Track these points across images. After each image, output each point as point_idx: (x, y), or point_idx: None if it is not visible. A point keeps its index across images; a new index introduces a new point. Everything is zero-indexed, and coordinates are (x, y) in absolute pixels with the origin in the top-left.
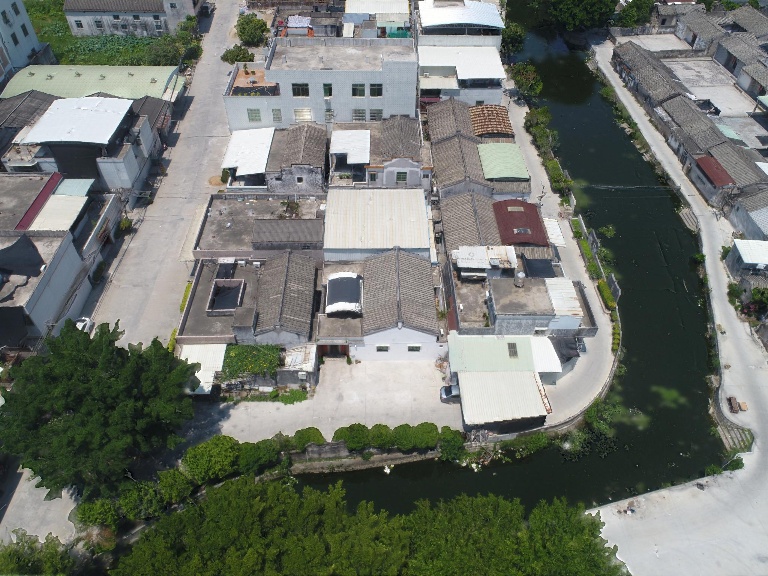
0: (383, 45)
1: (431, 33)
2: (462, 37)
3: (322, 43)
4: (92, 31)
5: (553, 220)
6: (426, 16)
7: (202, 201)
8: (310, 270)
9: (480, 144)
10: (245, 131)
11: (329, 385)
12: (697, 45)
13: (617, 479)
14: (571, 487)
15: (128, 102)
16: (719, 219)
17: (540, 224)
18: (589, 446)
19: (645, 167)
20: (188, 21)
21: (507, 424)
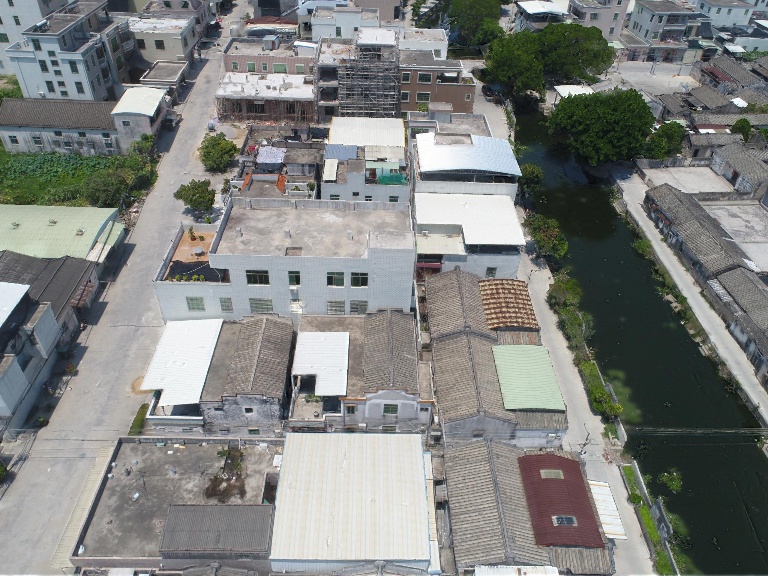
0: (371, 209)
1: (431, 176)
2: (469, 184)
3: (292, 206)
4: (29, 147)
5: (603, 484)
6: (425, 156)
7: (116, 422)
8: None
9: (496, 345)
10: (183, 323)
11: None
12: (740, 185)
13: None
14: None
15: (21, 289)
16: None
17: (588, 501)
18: None
19: (703, 362)
20: (143, 141)
21: None
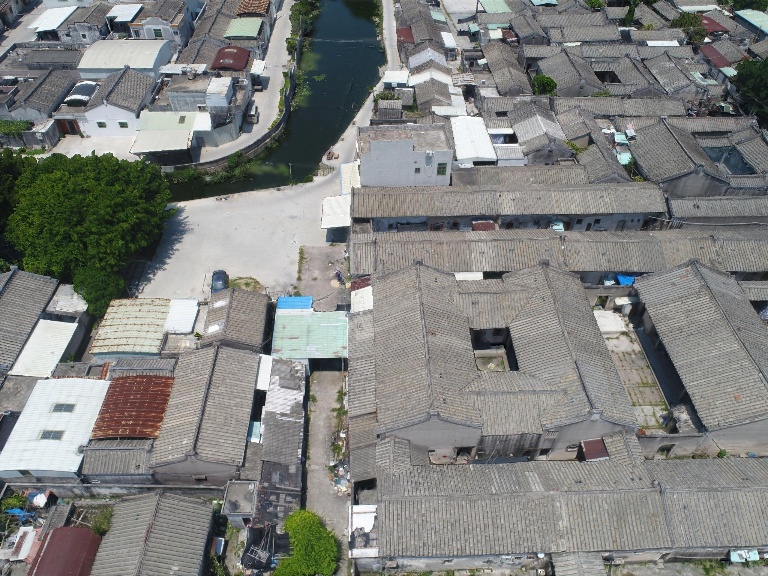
0: None
1: None
2: None
3: None
4: None
5: (262, 61)
6: None
7: None
8: (65, 82)
9: (234, 19)
10: (56, 9)
11: (63, 147)
12: None
13: (234, 192)
14: (203, 197)
15: None
16: (401, 69)
17: (245, 60)
18: (226, 178)
19: None
20: None
21: (161, 156)
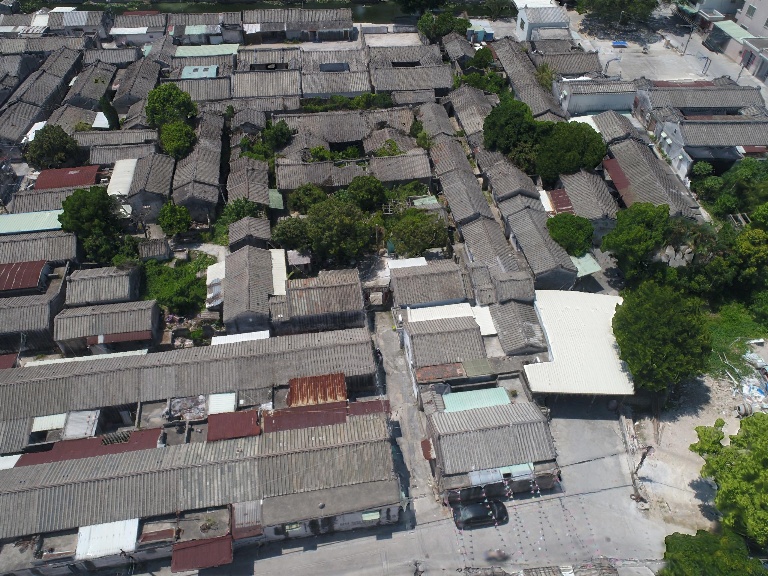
0: None
1: None
2: None
3: None
4: None
5: None
6: None
7: None
8: None
9: None
10: None
11: None
12: None
13: None
14: None
15: None
16: None
17: None
18: None
19: None
20: None
21: None
